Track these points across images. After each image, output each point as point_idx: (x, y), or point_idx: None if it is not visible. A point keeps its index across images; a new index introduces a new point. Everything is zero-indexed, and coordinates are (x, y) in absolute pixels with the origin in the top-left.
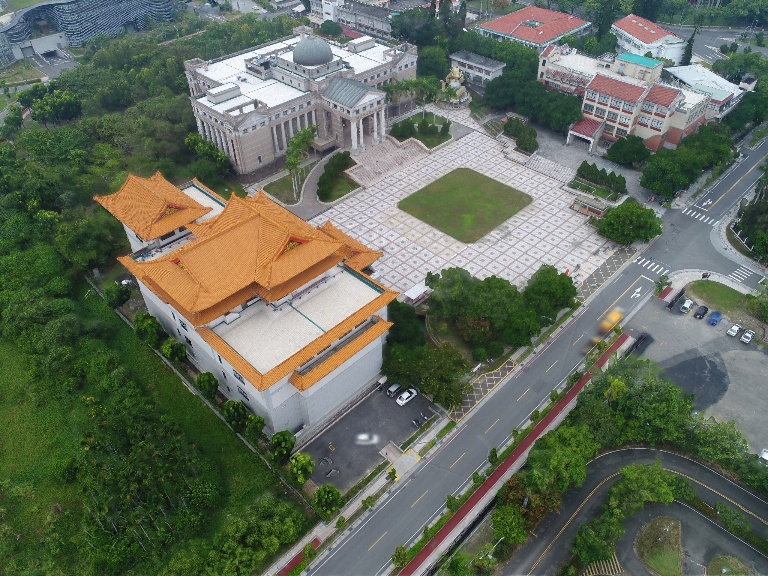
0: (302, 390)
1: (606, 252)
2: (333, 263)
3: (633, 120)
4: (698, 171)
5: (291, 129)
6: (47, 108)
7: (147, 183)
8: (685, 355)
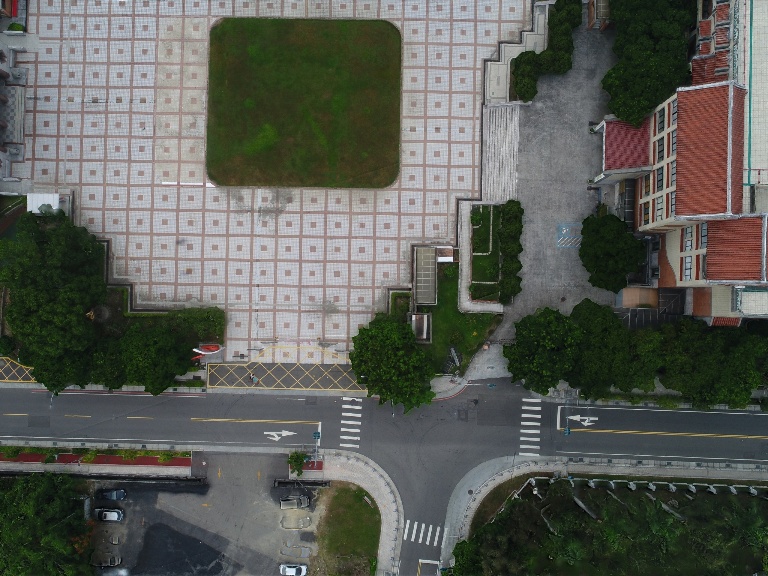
0: None
1: (338, 354)
2: None
3: None
4: (605, 392)
5: None
6: None
7: None
8: (207, 536)
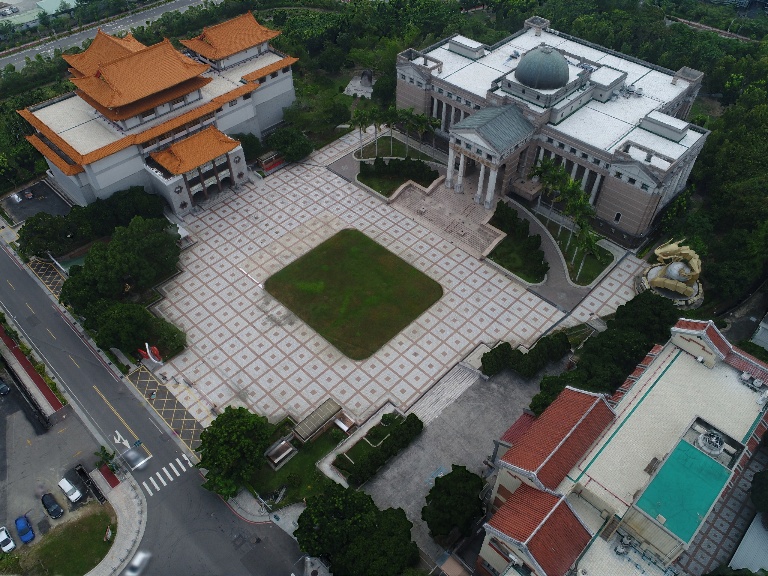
0: (25, 137)
1: None
2: (110, 117)
3: (499, 484)
4: None
5: (452, 117)
6: (498, 0)
7: (249, 25)
8: (1, 462)
